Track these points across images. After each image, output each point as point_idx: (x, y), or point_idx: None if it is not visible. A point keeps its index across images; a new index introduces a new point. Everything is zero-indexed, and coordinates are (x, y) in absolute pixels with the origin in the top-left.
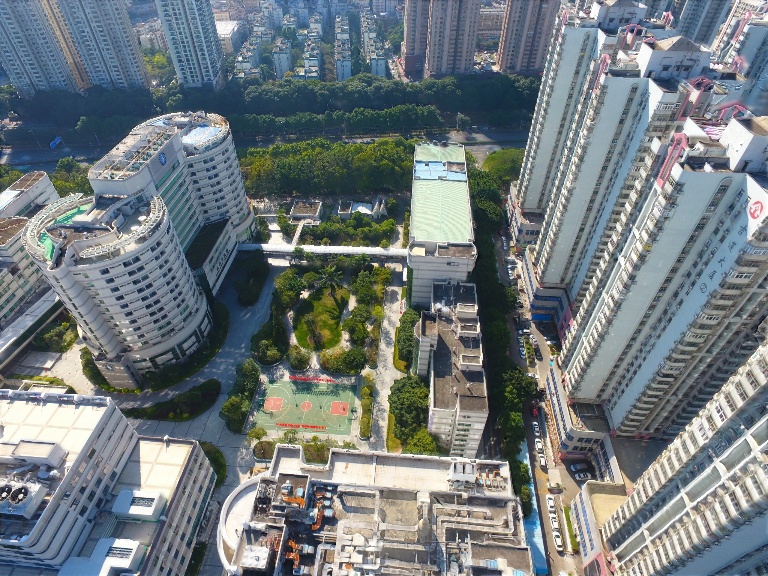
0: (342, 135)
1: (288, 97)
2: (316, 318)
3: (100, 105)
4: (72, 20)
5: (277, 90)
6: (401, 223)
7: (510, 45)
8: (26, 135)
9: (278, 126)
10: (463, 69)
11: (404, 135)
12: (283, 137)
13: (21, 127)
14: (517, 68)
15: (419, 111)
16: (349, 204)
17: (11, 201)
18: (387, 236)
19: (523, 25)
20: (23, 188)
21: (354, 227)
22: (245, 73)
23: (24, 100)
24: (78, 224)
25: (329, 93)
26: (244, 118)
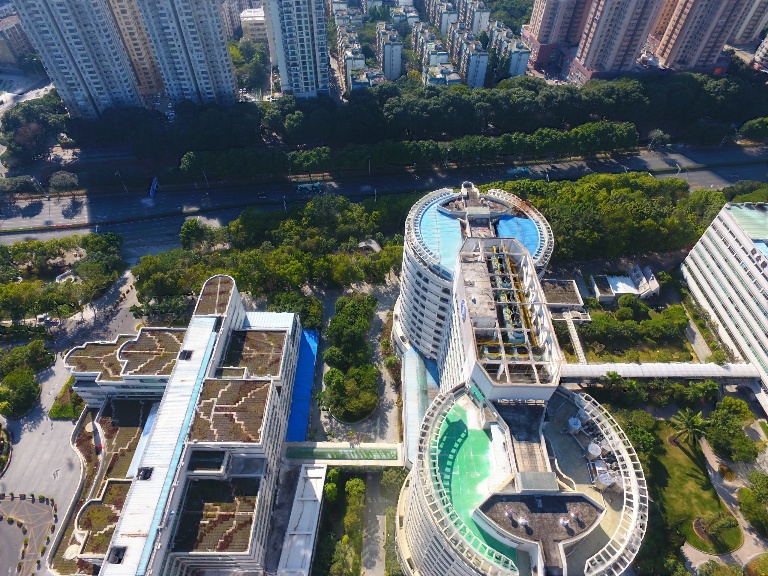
0: (512, 161)
1: (440, 112)
2: (683, 490)
3: (198, 129)
4: (149, 11)
5: (424, 102)
6: (680, 305)
7: (687, 35)
8: (111, 179)
9: (445, 155)
10: (631, 66)
11: (588, 159)
12: (440, 166)
13: (83, 158)
14: (692, 63)
15: (617, 131)
16: (605, 280)
17: (214, 341)
18: (681, 330)
19: (714, 11)
20: (216, 311)
21: (633, 318)
22: (367, 76)
23: (81, 120)
24: (529, 492)
25: (491, 105)
26: (403, 147)
